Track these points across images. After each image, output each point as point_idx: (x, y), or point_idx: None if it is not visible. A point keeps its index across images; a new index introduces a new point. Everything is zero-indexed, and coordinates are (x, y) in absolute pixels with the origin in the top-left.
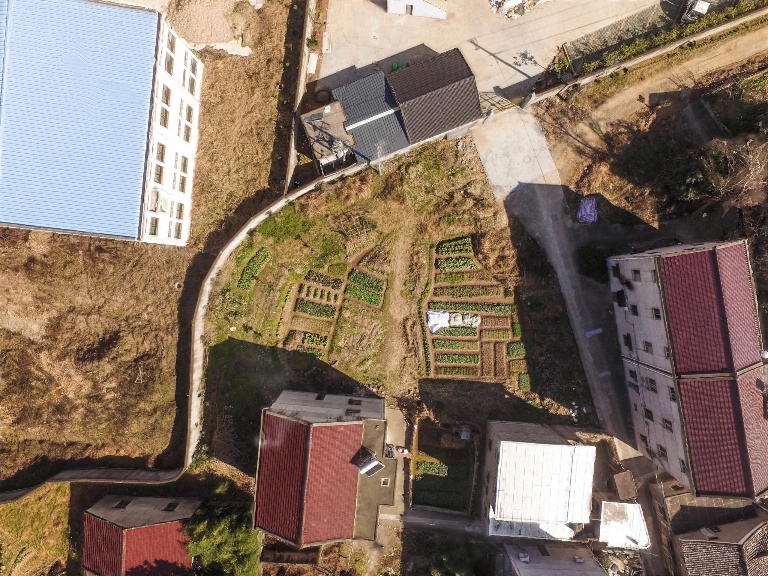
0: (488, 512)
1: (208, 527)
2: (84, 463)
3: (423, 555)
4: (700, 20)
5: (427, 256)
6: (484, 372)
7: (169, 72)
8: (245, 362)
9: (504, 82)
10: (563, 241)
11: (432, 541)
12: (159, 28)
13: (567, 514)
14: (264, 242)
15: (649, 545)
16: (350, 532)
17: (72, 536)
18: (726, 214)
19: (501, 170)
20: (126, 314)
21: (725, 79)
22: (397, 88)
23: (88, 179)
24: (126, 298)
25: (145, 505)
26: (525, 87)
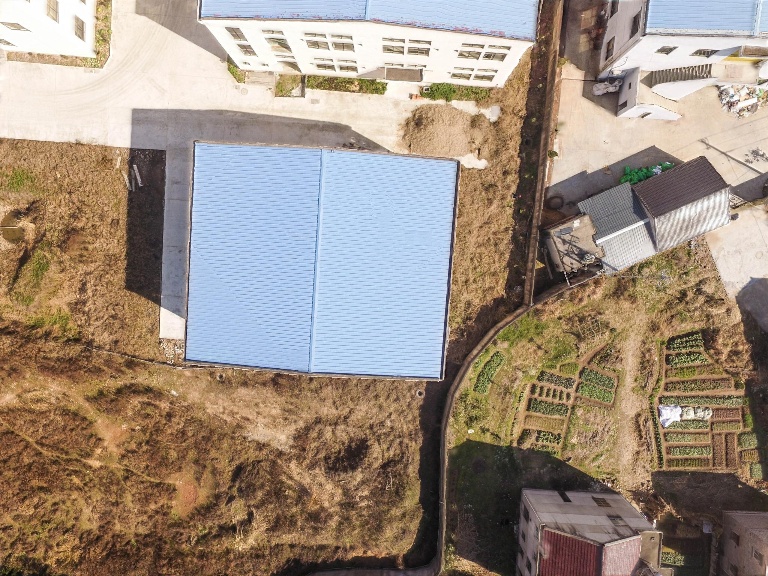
0: None
1: None
2: (332, 564)
3: None
4: None
5: (658, 352)
6: (716, 463)
7: None
8: (483, 462)
9: (736, 180)
10: None
11: None
12: (459, 176)
13: None
14: (499, 347)
15: None
16: None
17: None
18: None
19: (733, 266)
20: (370, 422)
21: None
22: (648, 200)
23: (395, 325)
24: (369, 407)
25: None
26: (757, 184)
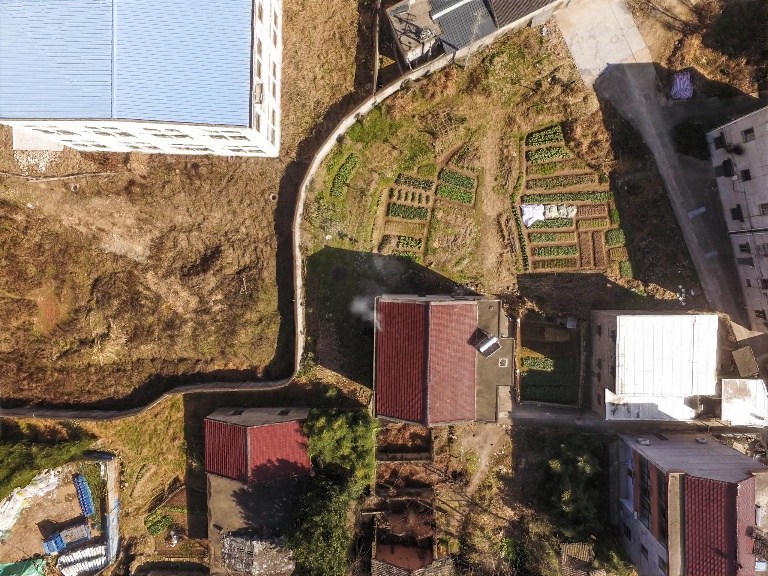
0: (603, 397)
1: (327, 422)
2: (195, 379)
3: (535, 450)
4: None
5: (517, 149)
6: (583, 263)
7: None
8: (342, 269)
9: None
10: (658, 120)
11: (543, 436)
12: None
13: (691, 386)
14: (353, 148)
15: None
16: (471, 414)
17: (189, 450)
18: None
19: (588, 53)
20: (225, 229)
21: None
22: None
23: (199, 71)
24: (224, 214)
25: (259, 412)
26: None
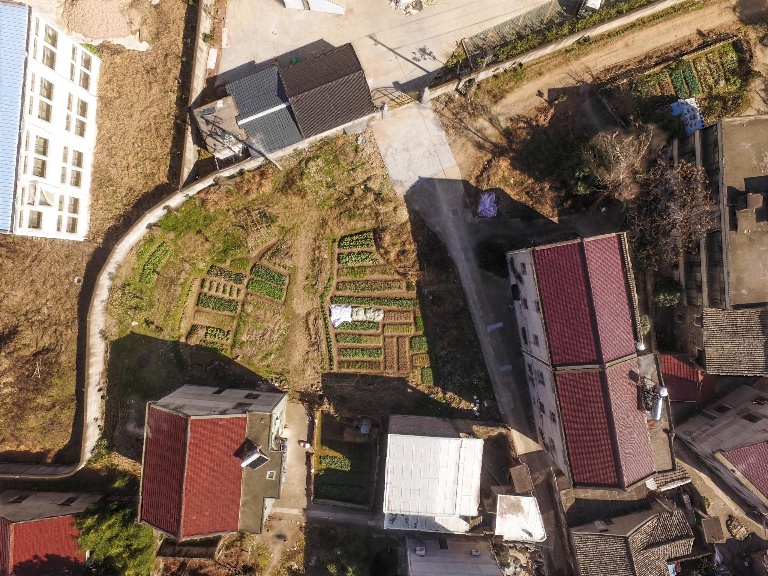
0: None
1: (98, 521)
2: None
3: (325, 549)
4: (592, 15)
5: (329, 251)
6: (387, 366)
7: (50, 66)
8: (147, 357)
9: (403, 77)
10: (464, 235)
11: (334, 535)
12: (29, 21)
13: (455, 507)
14: (165, 237)
15: (545, 538)
16: (235, 525)
17: None
18: (625, 208)
19: (401, 165)
20: (26, 309)
21: (622, 74)
22: (288, 83)
23: None
24: (26, 293)
25: (42, 500)
26: (424, 82)
